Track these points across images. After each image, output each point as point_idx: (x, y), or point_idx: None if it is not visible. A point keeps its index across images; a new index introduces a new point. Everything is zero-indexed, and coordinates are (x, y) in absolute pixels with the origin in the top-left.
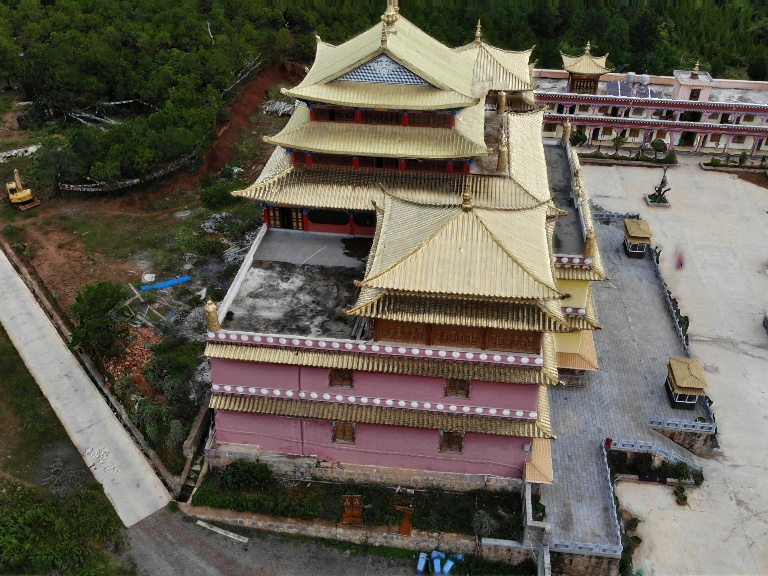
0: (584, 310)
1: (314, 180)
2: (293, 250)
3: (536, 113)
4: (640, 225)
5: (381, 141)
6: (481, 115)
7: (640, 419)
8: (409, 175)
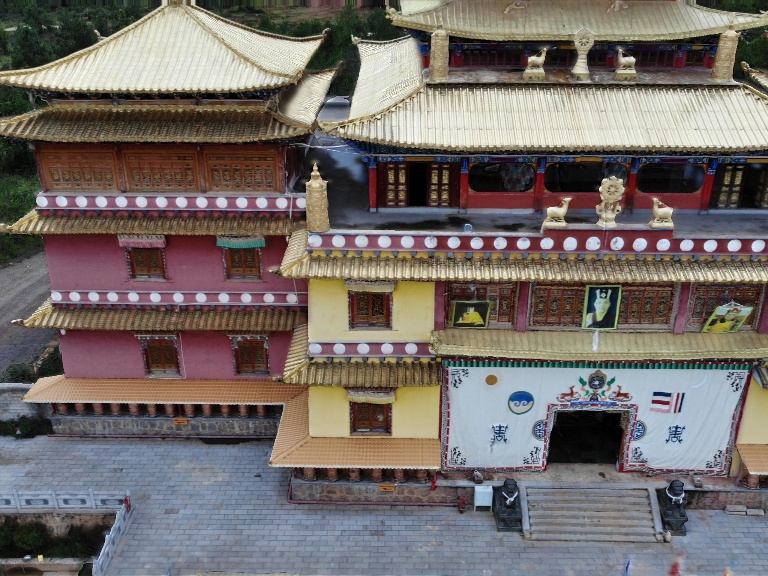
0: (312, 347)
1: (395, 51)
2: (338, 116)
3: None
4: None
5: (421, 6)
6: (595, 32)
7: (190, 574)
8: (414, 62)
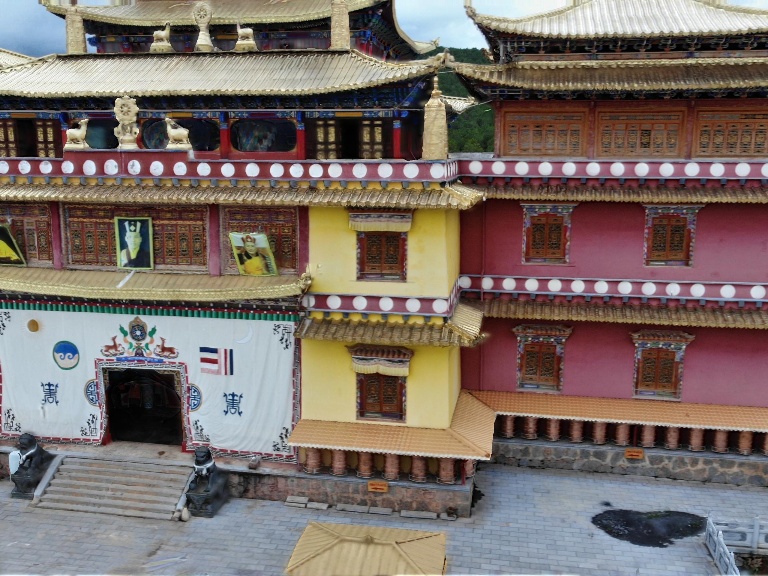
0: None
1: None
2: None
3: (411, 68)
4: (371, 544)
5: None
6: None
7: None
8: None
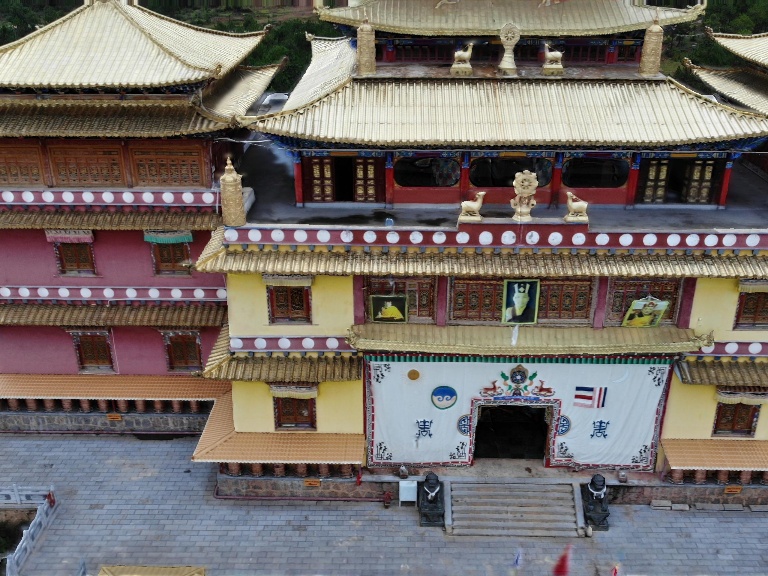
0: (233, 342)
1: (344, 47)
2: None
3: (762, 120)
4: None
5: None
6: (525, 27)
7: None
8: None
